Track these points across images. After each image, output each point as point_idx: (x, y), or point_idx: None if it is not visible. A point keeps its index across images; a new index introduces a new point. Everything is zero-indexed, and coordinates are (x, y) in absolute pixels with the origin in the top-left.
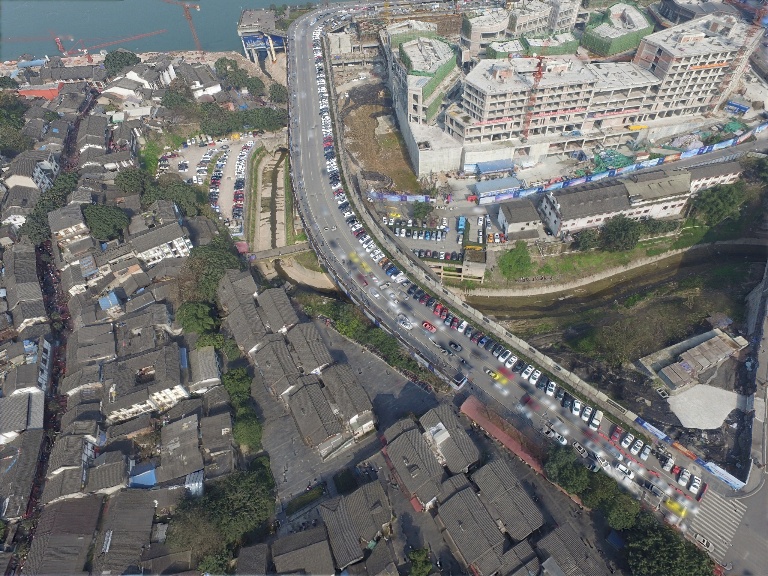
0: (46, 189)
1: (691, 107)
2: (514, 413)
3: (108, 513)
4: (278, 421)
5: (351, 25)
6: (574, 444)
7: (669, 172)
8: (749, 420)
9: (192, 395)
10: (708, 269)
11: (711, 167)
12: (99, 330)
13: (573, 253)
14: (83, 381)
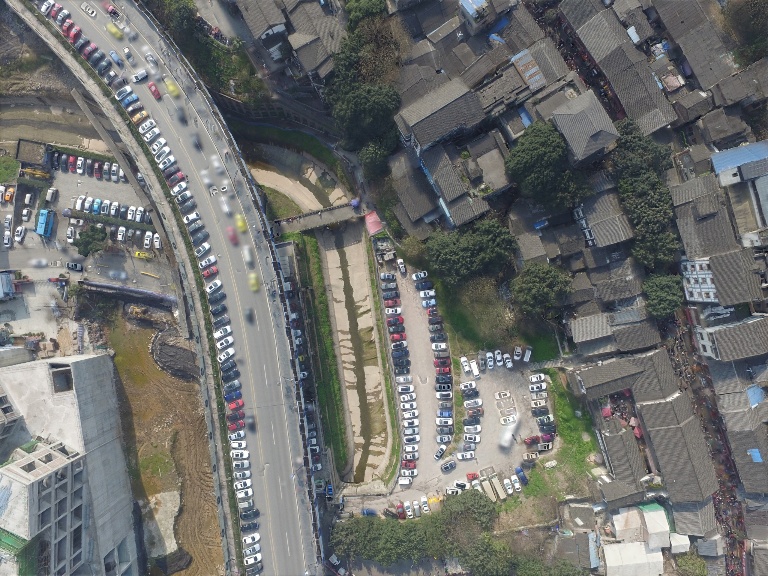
0: None
1: None
2: None
3: None
4: None
5: None
6: None
7: None
8: None
9: None
10: None
11: None
12: None
13: None
14: None
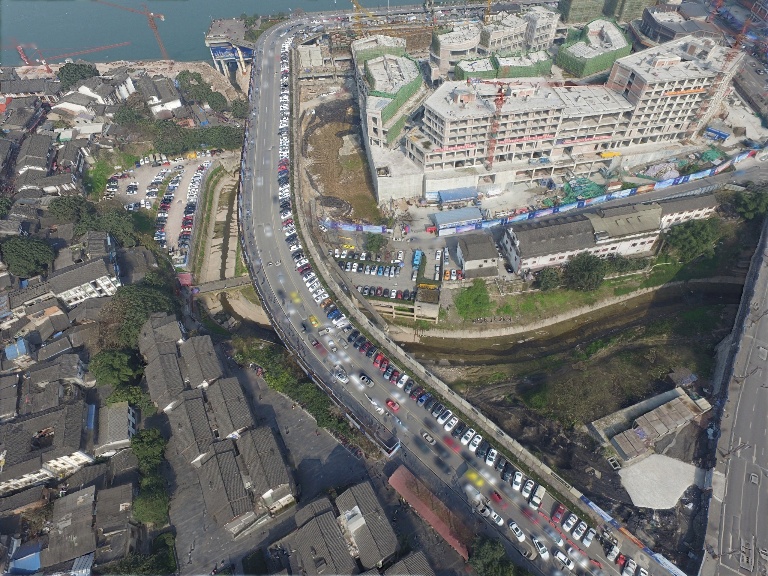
0: None
1: (667, 134)
2: (449, 486)
3: None
4: (191, 489)
5: (323, 37)
6: (511, 525)
7: (639, 206)
8: (706, 500)
9: (97, 459)
10: (679, 311)
11: (685, 201)
12: (2, 383)
13: (536, 291)
14: None
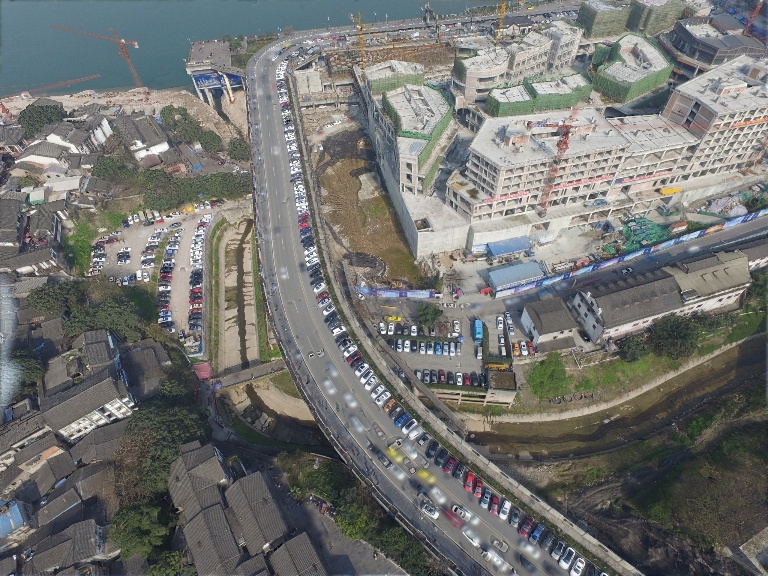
0: None
1: (729, 164)
2: None
3: None
4: None
5: (320, 58)
6: None
7: (721, 255)
8: None
9: None
10: None
11: (767, 245)
12: None
13: (614, 359)
14: None
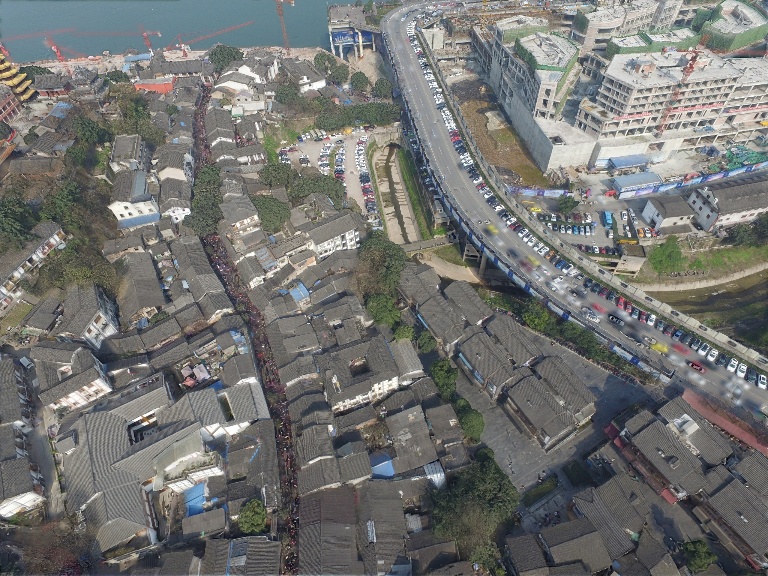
0: (196, 182)
1: None
2: (731, 406)
3: (361, 503)
4: (487, 413)
5: (441, 21)
6: None
7: None
8: None
9: (400, 387)
10: None
11: None
12: (296, 321)
13: (721, 248)
14: (303, 372)
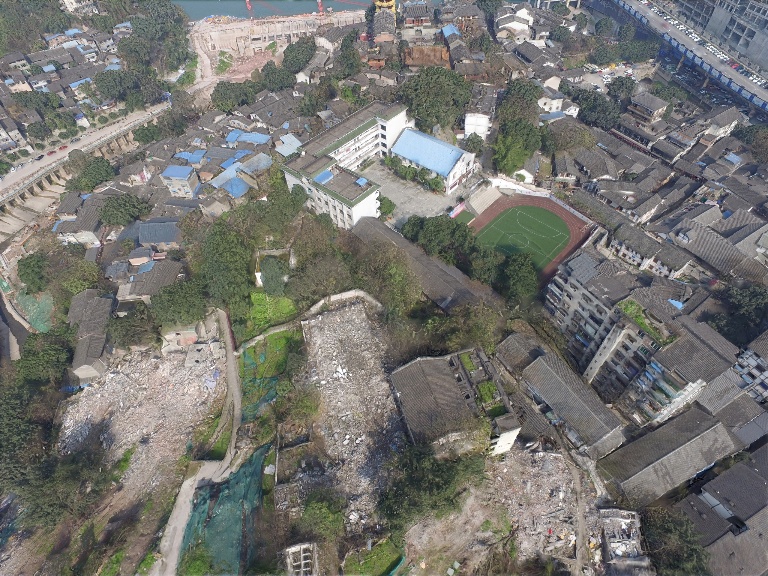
0: None
1: None
2: None
3: None
4: None
5: None
6: None
7: None
8: None
9: None
10: None
11: None
12: None
13: None
14: None
